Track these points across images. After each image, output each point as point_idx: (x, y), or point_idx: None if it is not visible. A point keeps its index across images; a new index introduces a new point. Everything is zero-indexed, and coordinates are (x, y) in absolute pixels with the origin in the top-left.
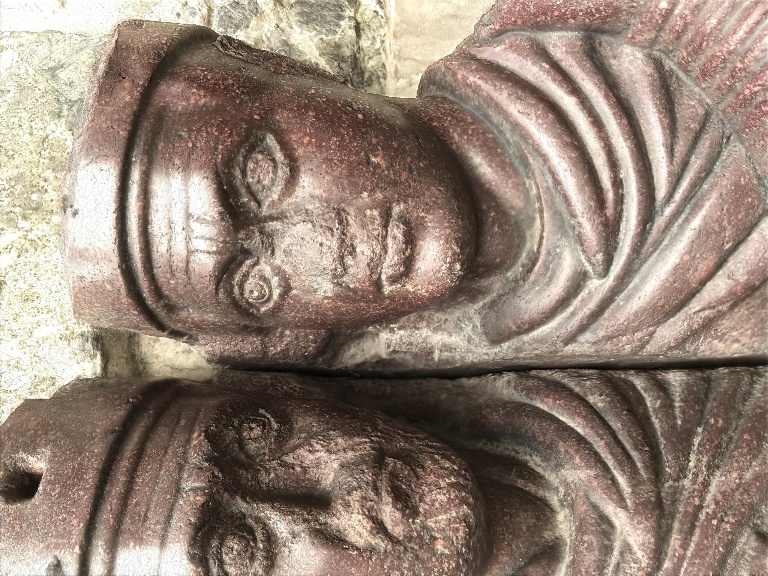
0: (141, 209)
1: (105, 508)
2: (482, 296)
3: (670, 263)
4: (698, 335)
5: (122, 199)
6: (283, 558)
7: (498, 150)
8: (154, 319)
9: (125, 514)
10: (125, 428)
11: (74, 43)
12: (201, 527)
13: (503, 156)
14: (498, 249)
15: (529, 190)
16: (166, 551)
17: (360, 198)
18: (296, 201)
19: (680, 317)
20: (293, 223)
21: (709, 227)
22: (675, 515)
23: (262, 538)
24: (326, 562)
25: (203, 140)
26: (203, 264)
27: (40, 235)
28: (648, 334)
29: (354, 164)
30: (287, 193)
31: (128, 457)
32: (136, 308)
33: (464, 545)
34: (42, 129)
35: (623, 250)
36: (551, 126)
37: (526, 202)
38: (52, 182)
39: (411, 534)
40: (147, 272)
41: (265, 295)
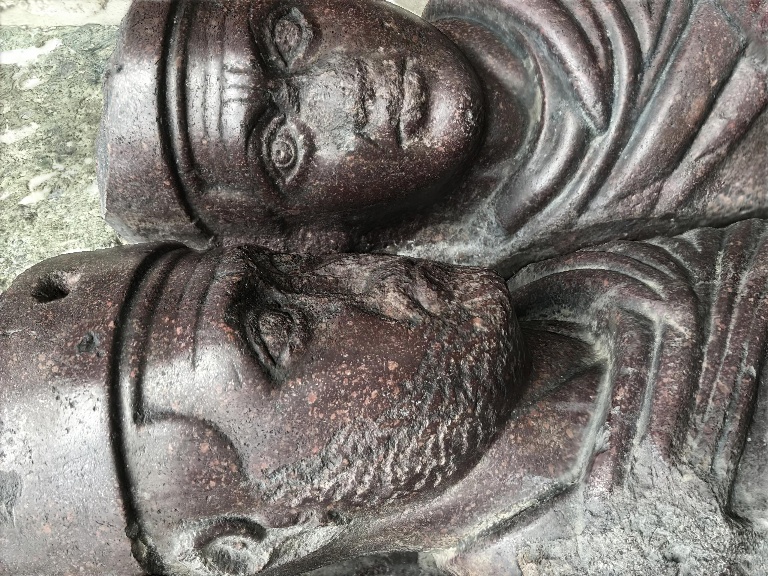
0: (180, 63)
1: (140, 295)
2: (494, 184)
3: (664, 106)
4: (703, 188)
5: (163, 53)
6: (321, 331)
7: (496, 41)
8: (184, 198)
9: (160, 299)
10: (158, 253)
11: (112, 31)
12: (237, 300)
13: (501, 45)
14: (505, 127)
15: (527, 69)
16: (203, 318)
17: (377, 52)
18: (319, 59)
19: (683, 167)
20: (317, 74)
21: (694, 67)
22: (711, 303)
23: (298, 317)
24: (365, 331)
25: (236, 6)
26: (235, 114)
27: (73, 174)
28: (656, 190)
29: (370, 26)
30: (311, 52)
31: (162, 264)
32: (169, 176)
33: (503, 326)
34: (80, 92)
35: (620, 100)
36: (540, 0)
37: (526, 80)
38: (87, 132)
39: (448, 312)
40: (182, 129)
41: (291, 157)
